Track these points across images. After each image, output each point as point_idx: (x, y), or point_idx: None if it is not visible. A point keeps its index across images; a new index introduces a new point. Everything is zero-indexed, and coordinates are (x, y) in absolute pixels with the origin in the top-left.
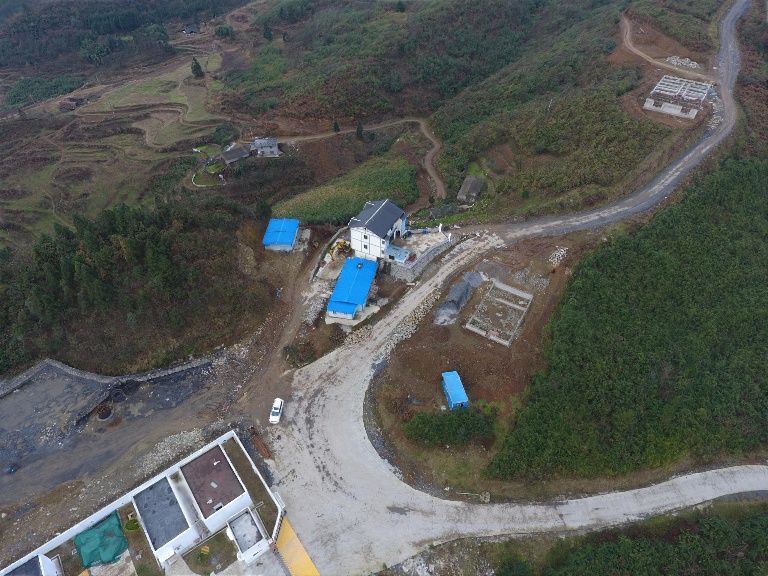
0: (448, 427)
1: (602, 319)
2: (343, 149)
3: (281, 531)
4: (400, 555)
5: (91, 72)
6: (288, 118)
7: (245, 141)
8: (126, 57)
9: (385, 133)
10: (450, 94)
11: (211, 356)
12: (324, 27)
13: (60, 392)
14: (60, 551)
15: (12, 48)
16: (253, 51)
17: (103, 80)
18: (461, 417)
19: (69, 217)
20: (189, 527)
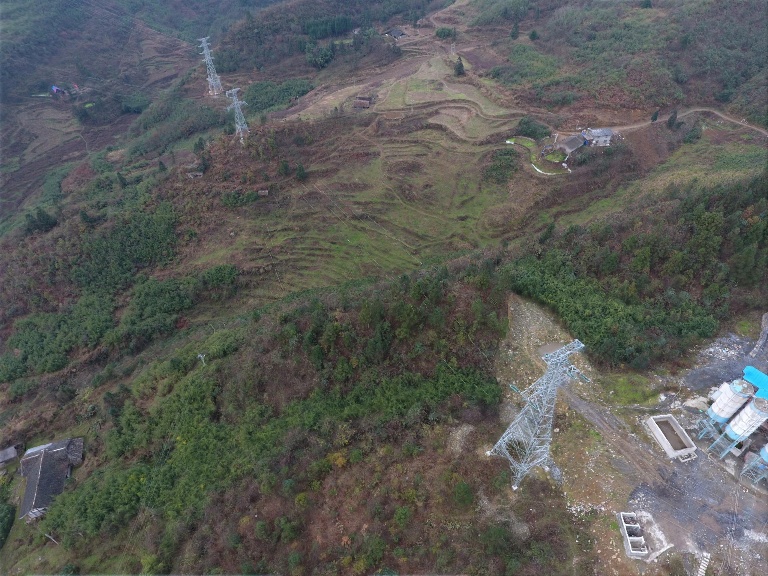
0: None
1: None
2: (658, 137)
3: None
4: None
5: (314, 75)
6: (600, 109)
7: (566, 132)
8: (358, 59)
9: (686, 122)
10: (733, 84)
11: None
12: (576, 24)
13: None
14: None
15: (239, 54)
16: (498, 50)
17: (338, 82)
18: None
19: (424, 207)
20: None
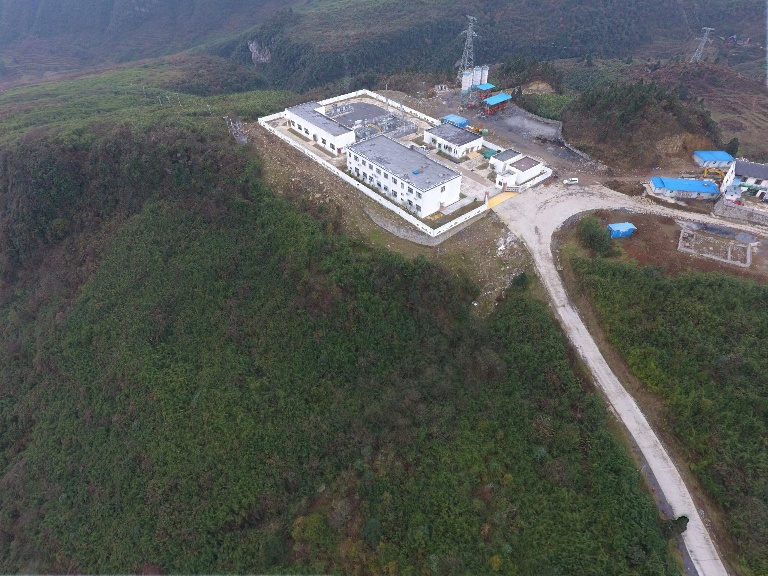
0: (592, 228)
1: (764, 314)
2: None
3: (512, 193)
4: (515, 231)
5: None
6: None
7: None
8: None
9: None
10: None
11: (593, 161)
12: None
13: (548, 131)
14: (485, 148)
15: None
16: None
17: None
18: (601, 231)
19: None
20: (503, 162)
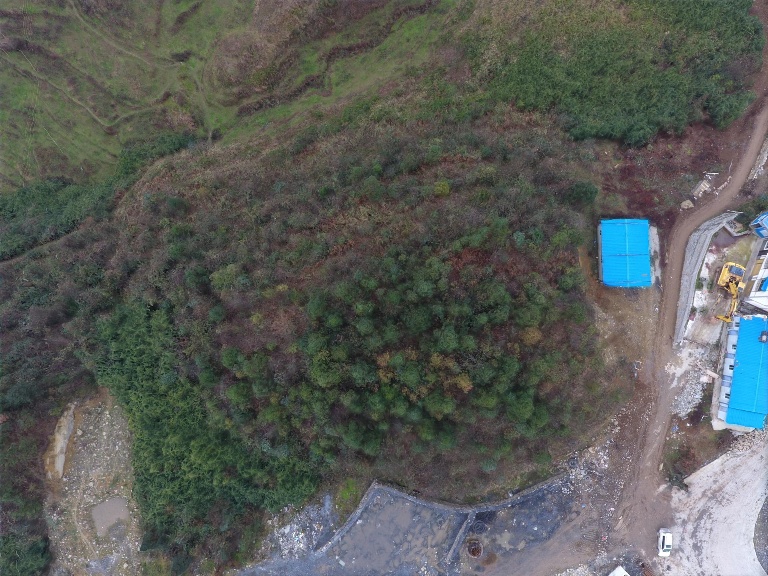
0: None
1: None
2: None
3: None
4: None
5: None
6: None
7: None
8: None
9: None
10: None
11: (563, 463)
12: None
13: (409, 521)
14: None
15: None
16: None
17: None
18: None
19: (112, 31)
20: None
